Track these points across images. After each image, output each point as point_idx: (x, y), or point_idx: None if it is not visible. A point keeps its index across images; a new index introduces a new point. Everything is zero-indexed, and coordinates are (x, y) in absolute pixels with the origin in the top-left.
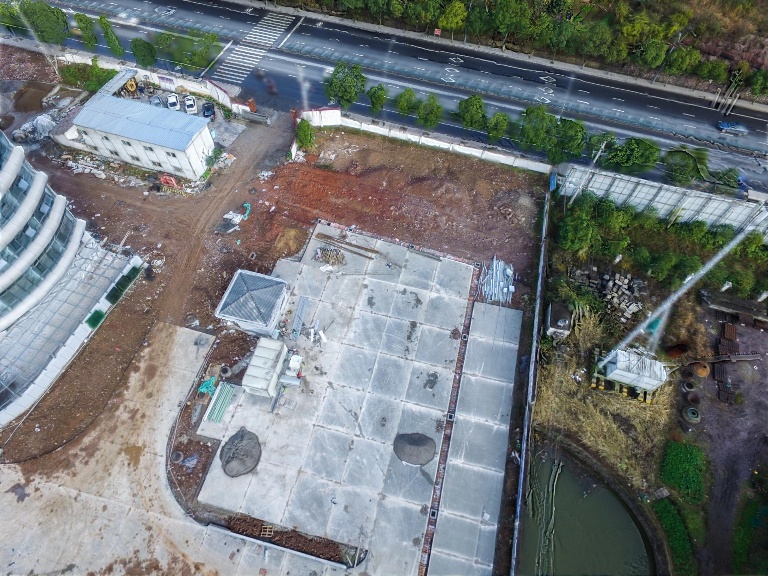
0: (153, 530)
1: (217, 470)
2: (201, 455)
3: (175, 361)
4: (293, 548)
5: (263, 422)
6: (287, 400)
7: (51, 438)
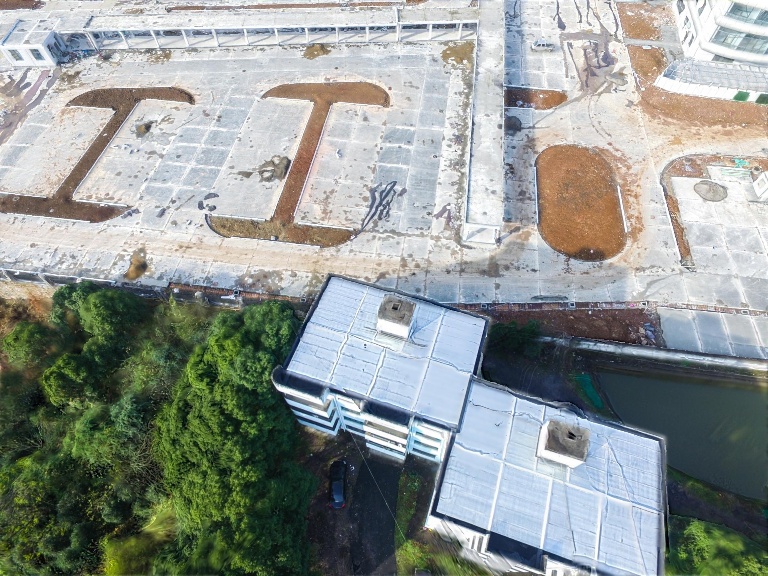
0: (644, 162)
1: (693, 181)
2: (695, 172)
3: (744, 142)
4: (674, 230)
5: (738, 198)
6: (763, 208)
7: (662, 105)
